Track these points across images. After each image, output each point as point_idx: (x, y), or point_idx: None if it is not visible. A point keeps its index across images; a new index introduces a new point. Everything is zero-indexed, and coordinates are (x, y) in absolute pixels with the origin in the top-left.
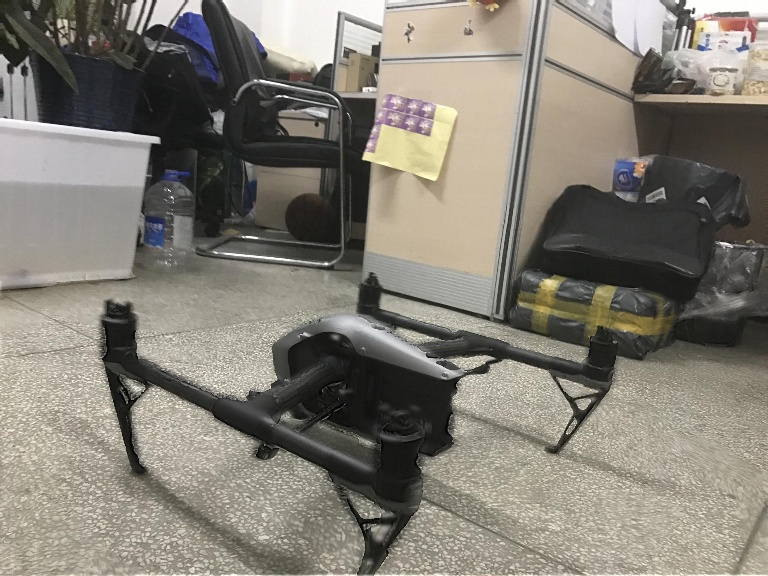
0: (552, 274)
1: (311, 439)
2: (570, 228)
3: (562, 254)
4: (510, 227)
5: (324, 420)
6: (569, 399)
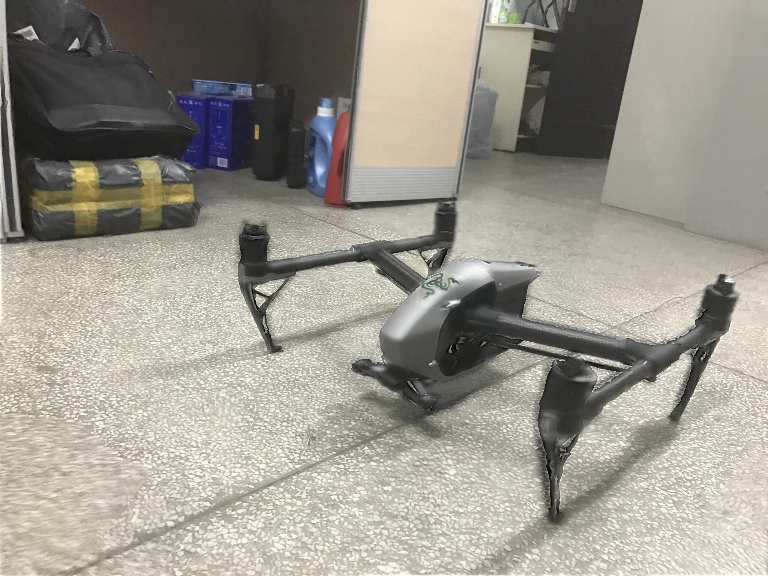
0: (67, 161)
1: None
2: (70, 99)
3: (88, 134)
4: (5, 108)
5: (465, 372)
6: (428, 264)
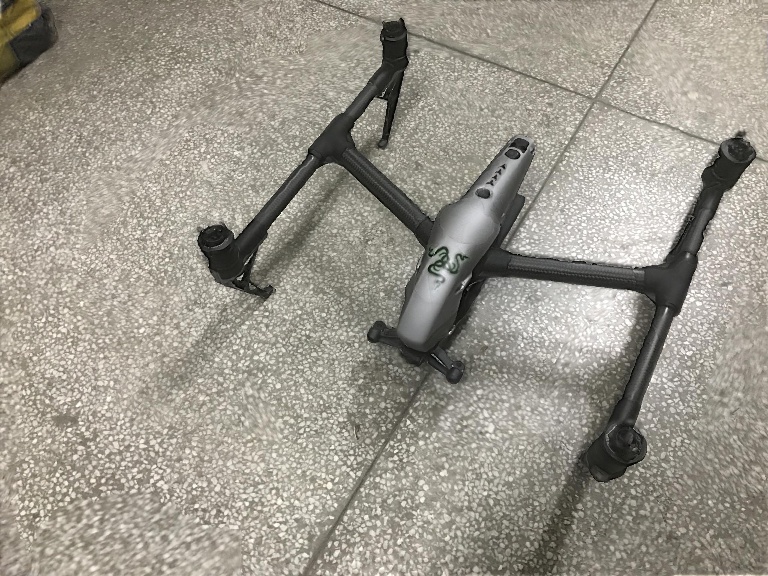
0: None
1: None
2: None
3: None
4: None
5: None
6: None
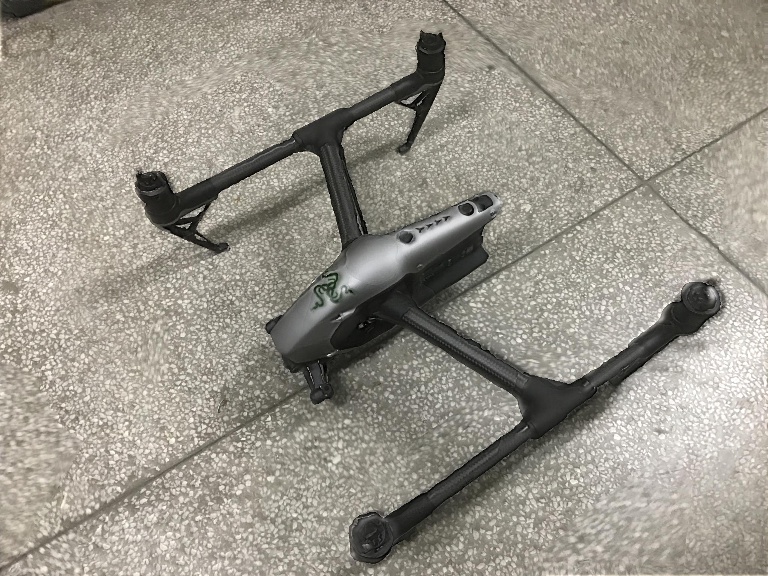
0: None
1: (352, 352)
2: None
3: None
4: None
5: None
6: (413, 107)
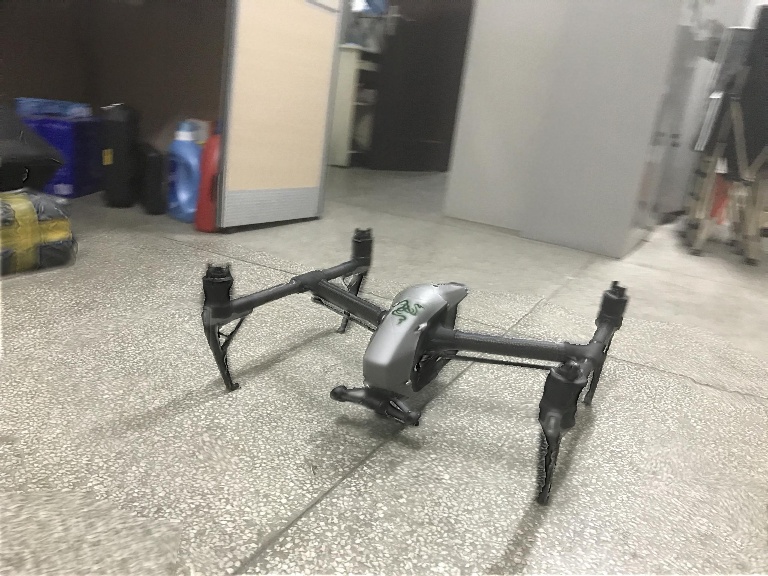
0: None
1: (399, 421)
2: None
3: None
4: None
5: None
6: (349, 288)
